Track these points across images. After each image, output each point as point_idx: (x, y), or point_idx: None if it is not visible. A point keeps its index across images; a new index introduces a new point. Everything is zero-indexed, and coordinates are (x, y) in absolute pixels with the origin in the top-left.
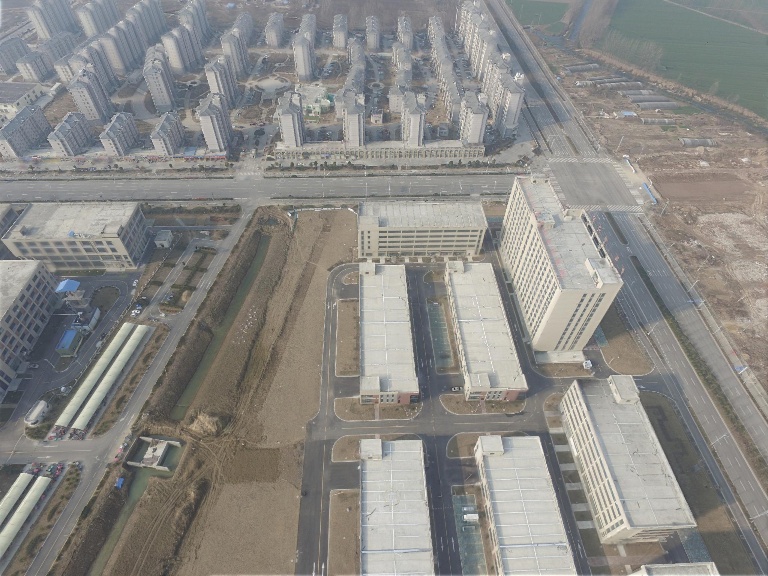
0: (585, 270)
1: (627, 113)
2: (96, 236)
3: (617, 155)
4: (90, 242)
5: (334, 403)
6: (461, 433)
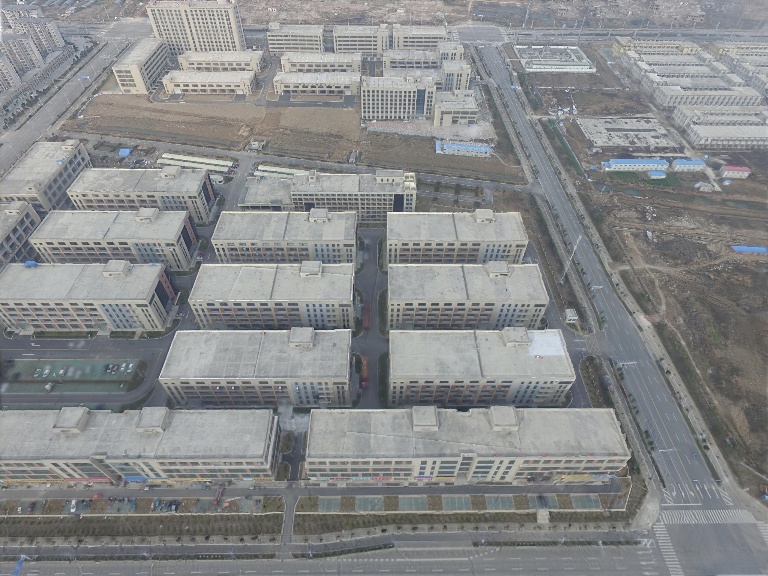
0: (222, 4)
1: (72, 8)
2: (69, 154)
3: (113, 20)
4: (72, 160)
5: (248, 100)
6: (275, 75)
